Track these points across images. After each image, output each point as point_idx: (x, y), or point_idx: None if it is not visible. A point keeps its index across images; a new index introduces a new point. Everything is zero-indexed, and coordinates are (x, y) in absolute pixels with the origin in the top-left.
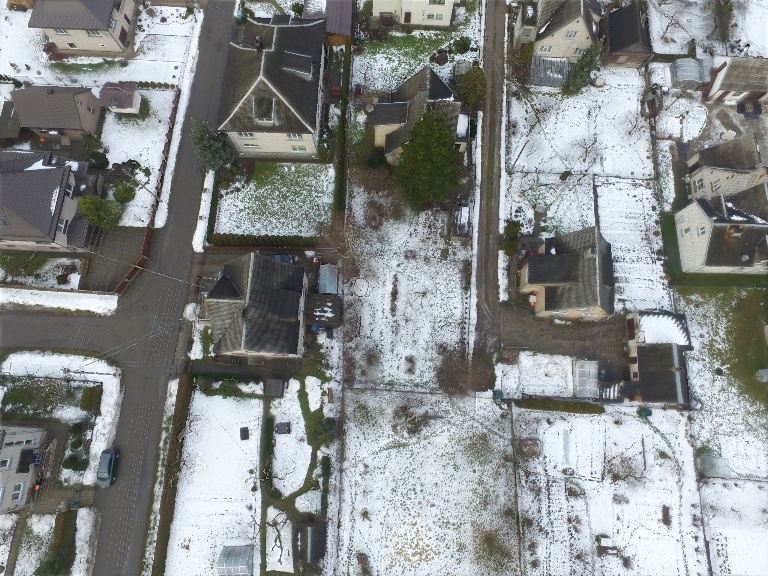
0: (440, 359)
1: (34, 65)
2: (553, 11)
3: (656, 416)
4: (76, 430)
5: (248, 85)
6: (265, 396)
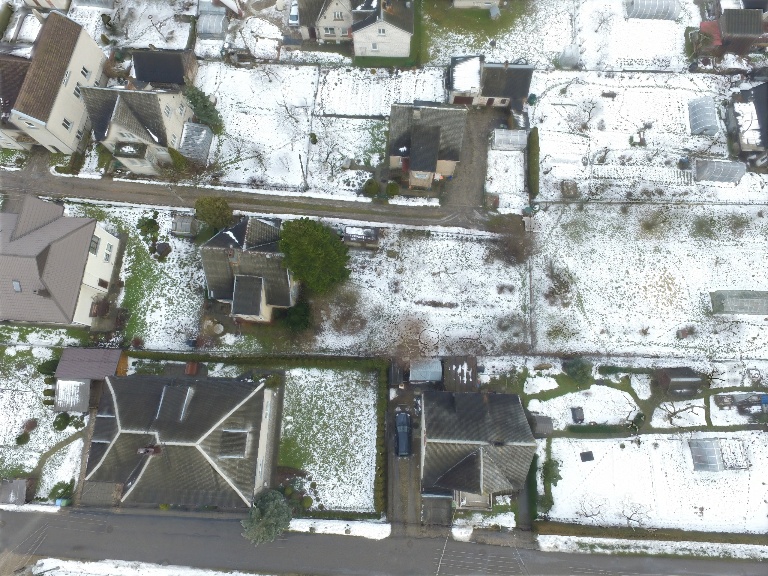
0: (498, 262)
1: None
2: (138, 124)
3: (533, 92)
4: None
5: (201, 465)
6: (548, 436)
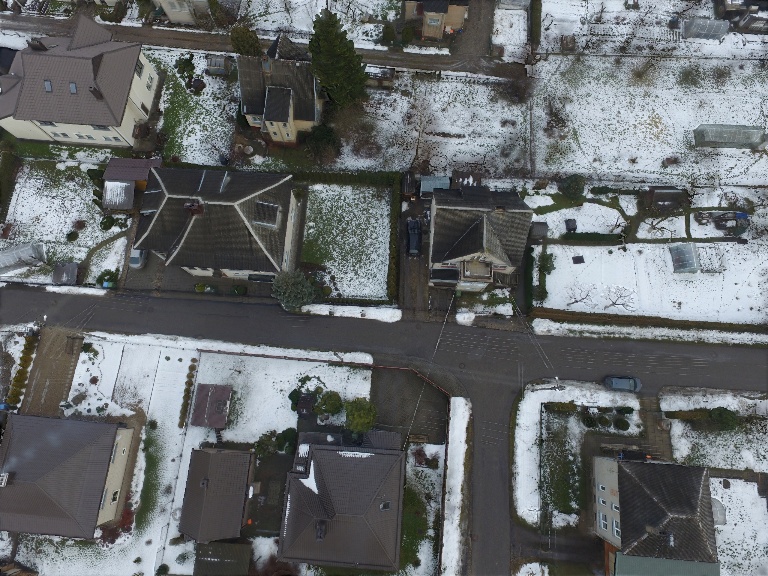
0: (502, 101)
1: (134, 553)
2: None
3: None
4: (593, 419)
5: (238, 226)
6: (543, 243)
